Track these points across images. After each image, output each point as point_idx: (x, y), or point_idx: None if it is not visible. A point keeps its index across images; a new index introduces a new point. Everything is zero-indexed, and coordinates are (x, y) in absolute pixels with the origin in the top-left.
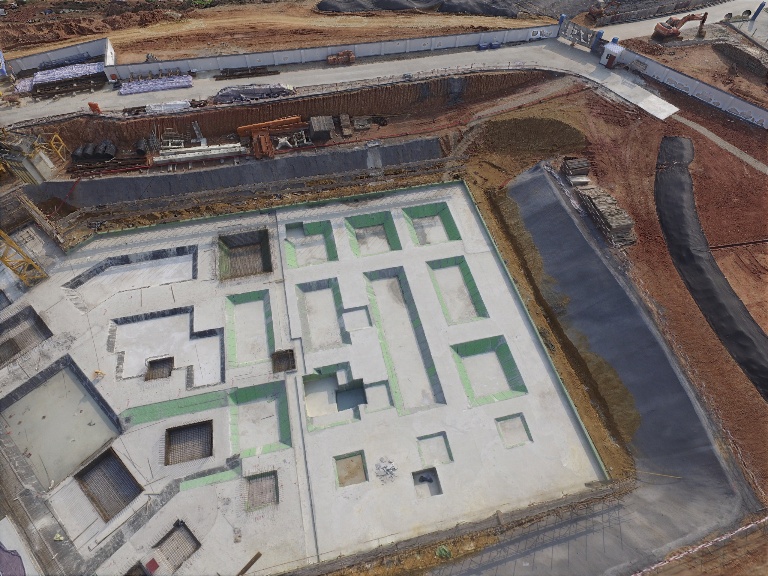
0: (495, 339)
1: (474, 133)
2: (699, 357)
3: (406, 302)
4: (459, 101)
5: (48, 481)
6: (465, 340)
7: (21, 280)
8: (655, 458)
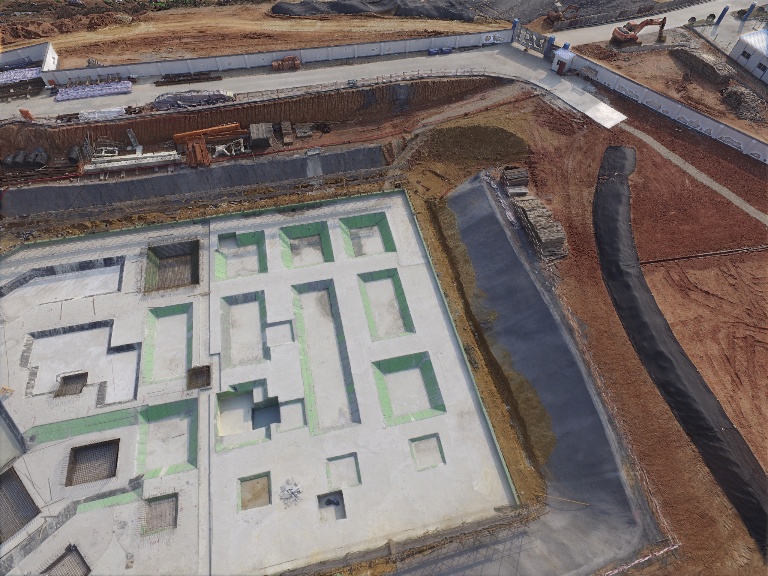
0: (419, 355)
1: (418, 141)
2: (616, 378)
3: (333, 316)
4: (406, 108)
5: None
6: (388, 356)
7: None
8: (566, 483)
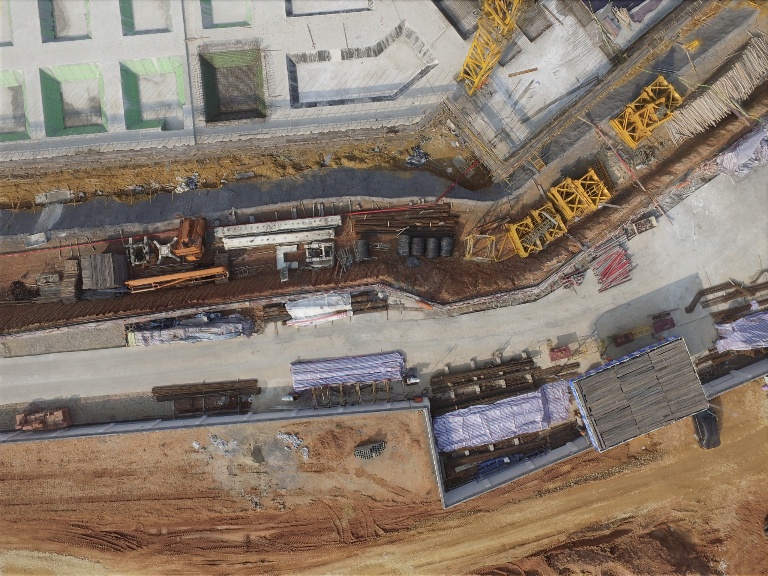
0: None
1: None
2: None
3: None
4: None
5: None
6: None
7: None
8: None
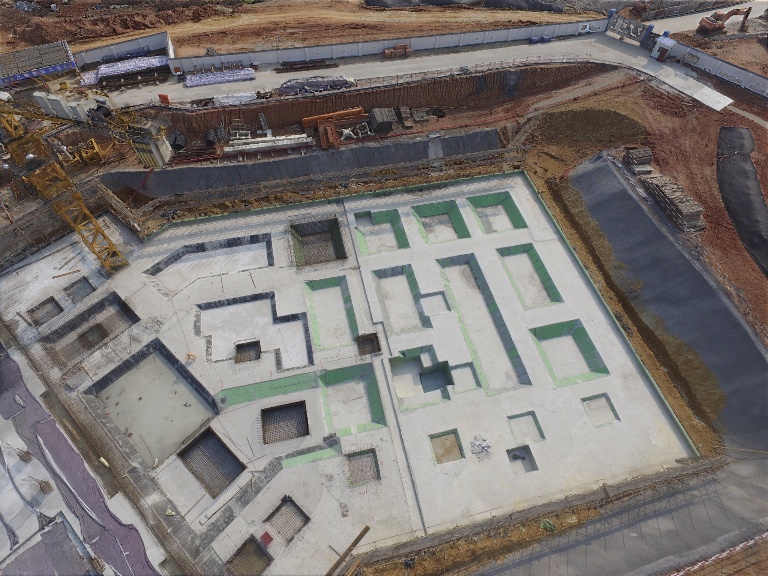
0: (571, 323)
1: (531, 124)
2: None
3: (480, 288)
4: (514, 93)
5: (152, 459)
6: (543, 324)
7: (102, 267)
8: (744, 435)
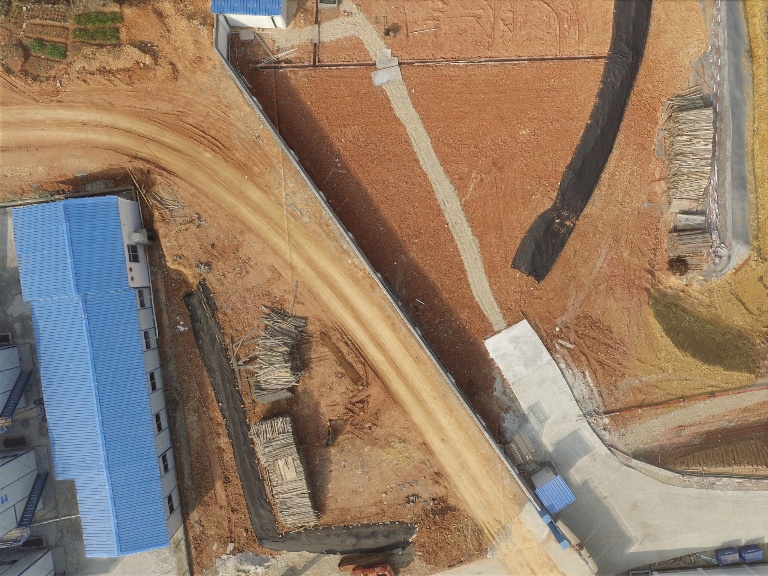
0: None
1: None
2: None
3: None
4: None
5: None
6: None
7: None
8: None
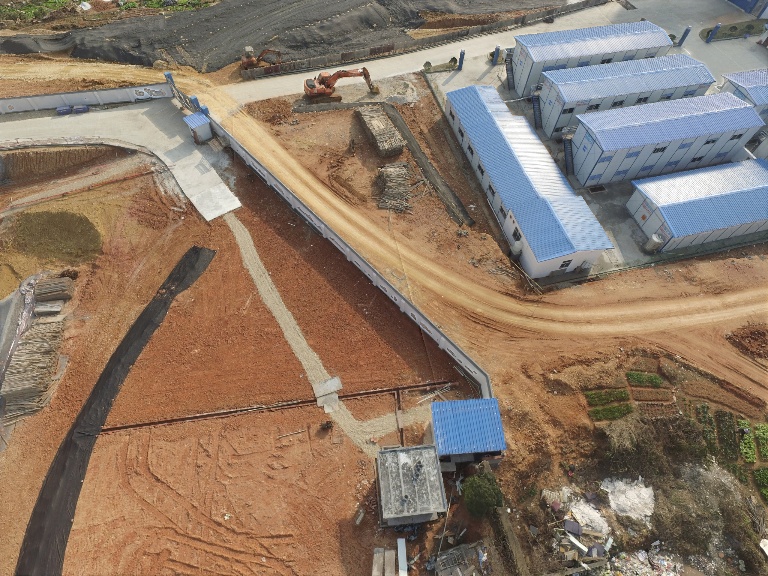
0: None
1: (2, 227)
2: None
3: None
4: (7, 182)
5: None
6: None
7: None
8: None
